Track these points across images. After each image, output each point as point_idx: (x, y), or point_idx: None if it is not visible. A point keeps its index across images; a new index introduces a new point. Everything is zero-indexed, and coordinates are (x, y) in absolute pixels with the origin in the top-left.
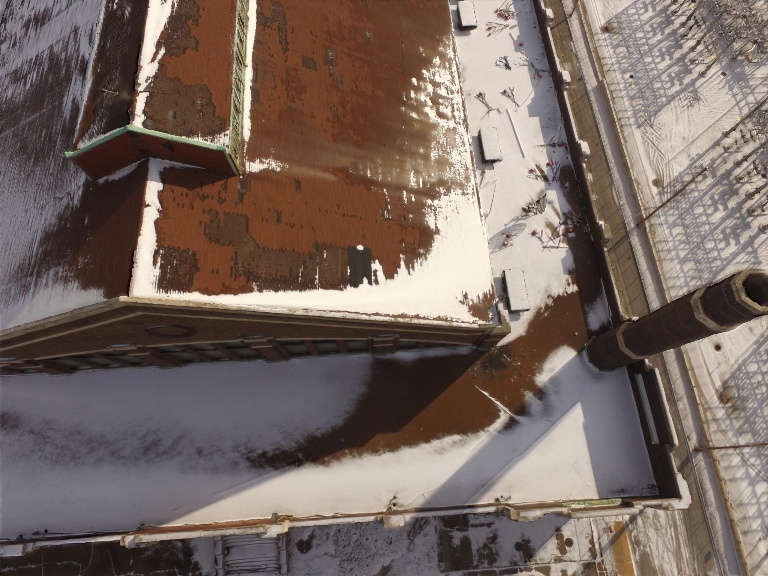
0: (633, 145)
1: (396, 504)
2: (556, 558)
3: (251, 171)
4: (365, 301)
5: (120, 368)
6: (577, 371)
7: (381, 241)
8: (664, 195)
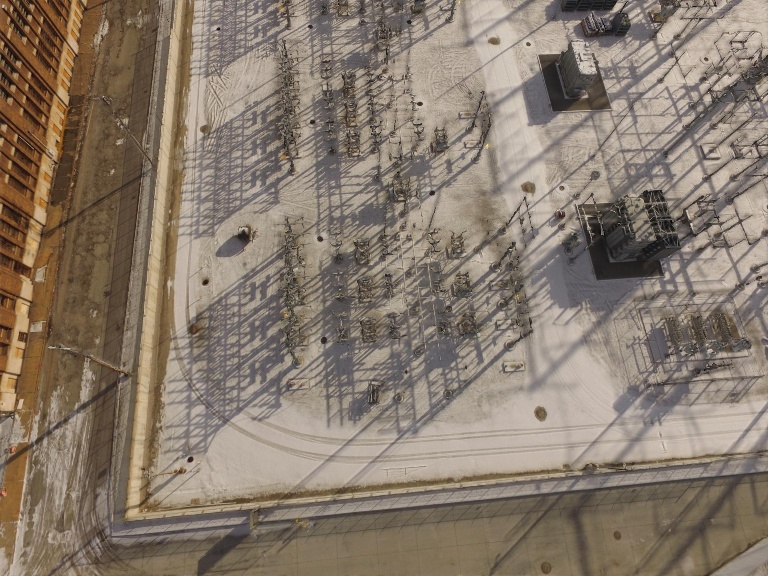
0: (195, 93)
1: None
2: None
3: None
4: None
5: None
6: None
7: None
8: (207, 140)
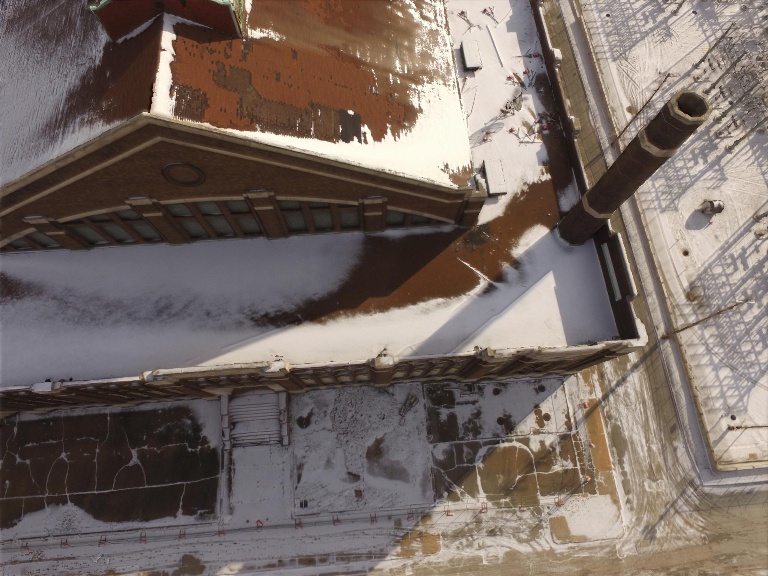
0: (609, 76)
1: (386, 355)
2: (535, 430)
3: (253, 37)
4: (355, 155)
5: (134, 245)
6: (550, 245)
7: (370, 110)
8: (637, 120)
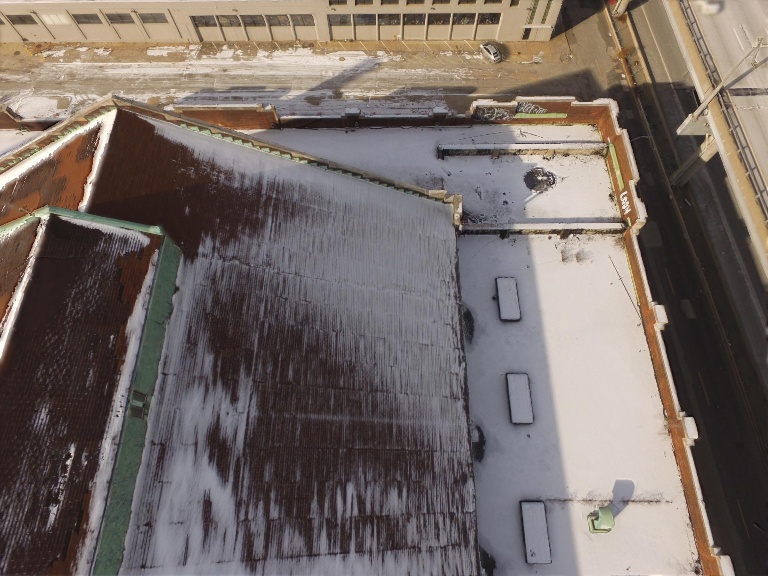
0: None
1: None
2: None
3: None
4: None
5: None
6: None
7: None
8: None
